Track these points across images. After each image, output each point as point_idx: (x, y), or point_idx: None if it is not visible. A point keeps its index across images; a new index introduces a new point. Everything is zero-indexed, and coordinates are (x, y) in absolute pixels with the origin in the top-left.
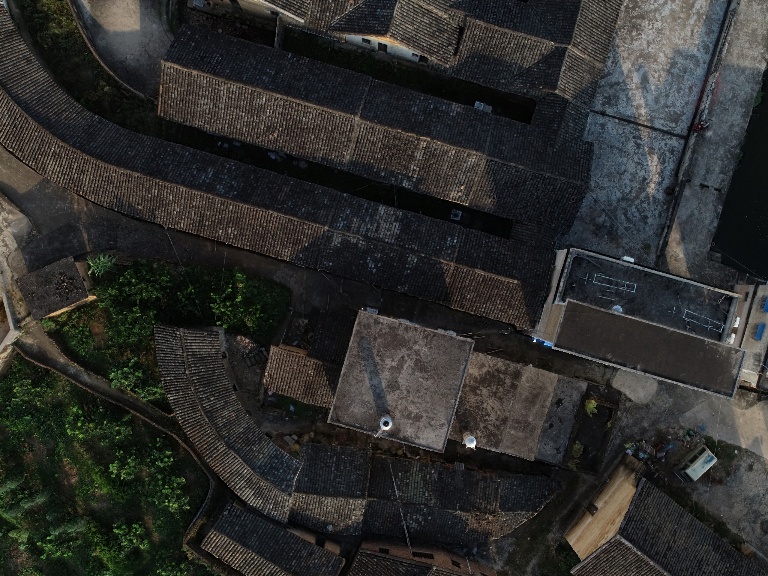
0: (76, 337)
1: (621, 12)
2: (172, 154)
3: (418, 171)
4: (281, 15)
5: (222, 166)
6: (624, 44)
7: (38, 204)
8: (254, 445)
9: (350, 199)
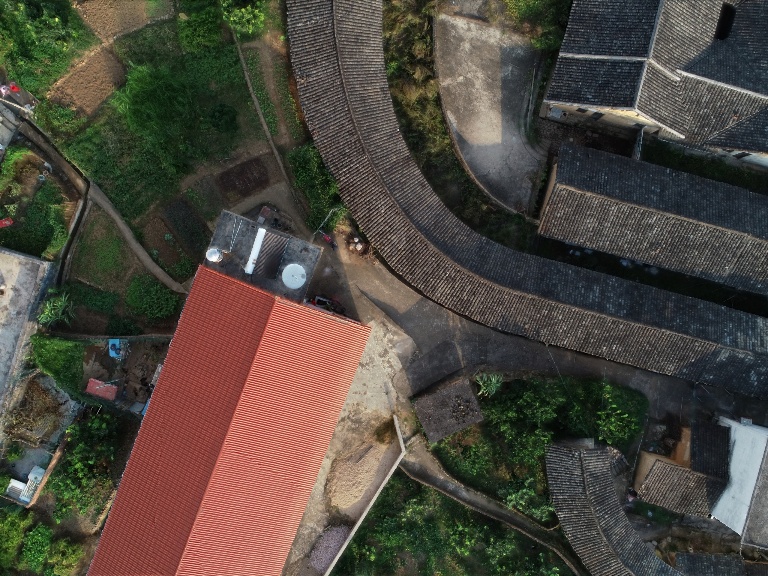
0: (468, 458)
1: None
2: (557, 273)
3: None
4: (646, 127)
5: (605, 283)
6: None
7: (417, 323)
8: (643, 560)
9: (729, 312)
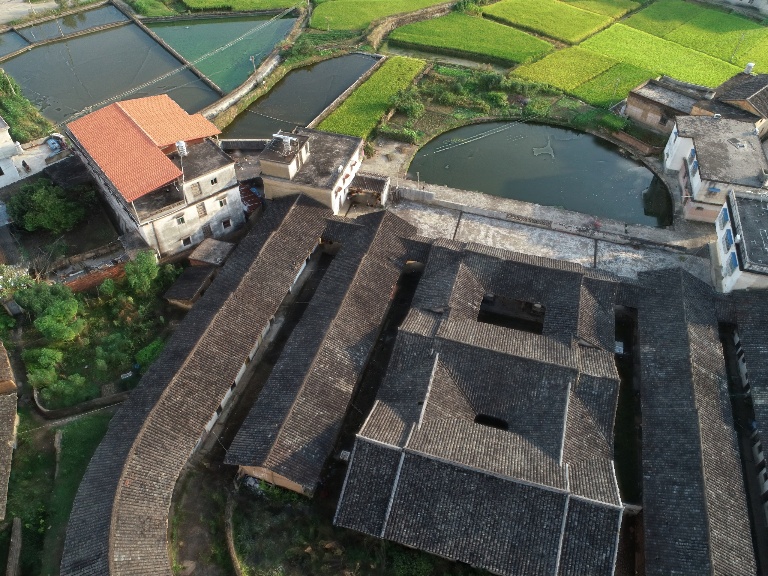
0: None
1: None
2: None
3: (713, 374)
4: None
5: None
6: None
7: None
8: None
9: (762, 427)
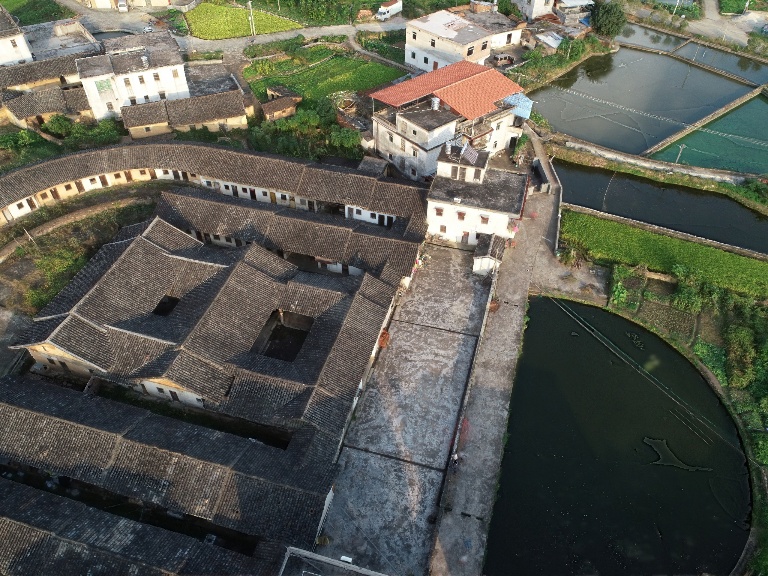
0: None
1: (382, 376)
2: None
3: (168, 486)
4: None
5: None
6: (385, 398)
7: None
8: None
9: (94, 512)
